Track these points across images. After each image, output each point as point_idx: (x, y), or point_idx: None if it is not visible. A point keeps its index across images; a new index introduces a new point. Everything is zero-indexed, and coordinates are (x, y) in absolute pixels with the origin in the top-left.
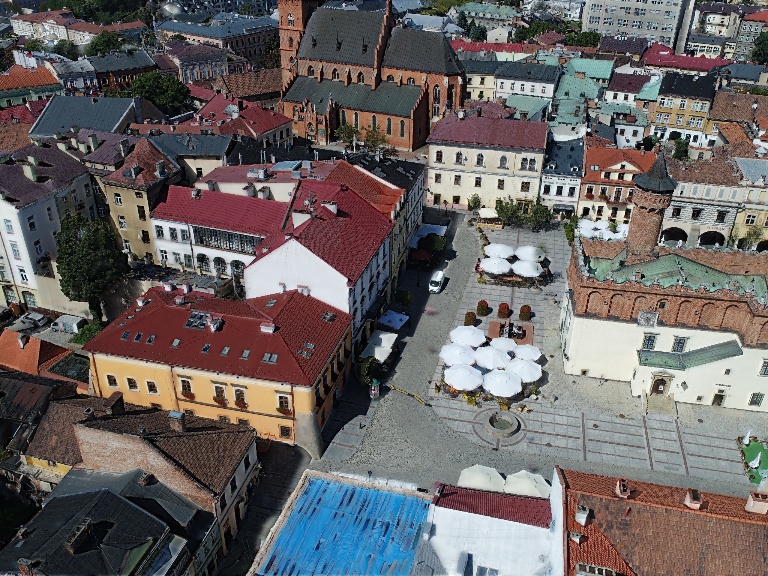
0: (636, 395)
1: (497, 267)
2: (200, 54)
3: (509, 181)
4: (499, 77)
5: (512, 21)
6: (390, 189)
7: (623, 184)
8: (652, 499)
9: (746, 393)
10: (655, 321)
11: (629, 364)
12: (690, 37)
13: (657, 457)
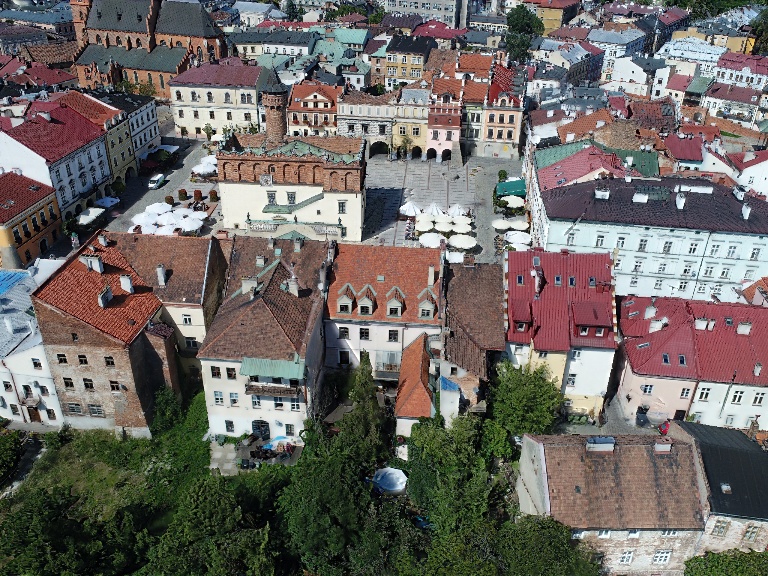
0: None
1: (203, 169)
2: (20, 33)
3: (235, 113)
4: (265, 43)
5: (326, 6)
6: (111, 110)
7: (318, 111)
8: None
9: None
10: (271, 182)
11: None
12: (486, 18)
13: None
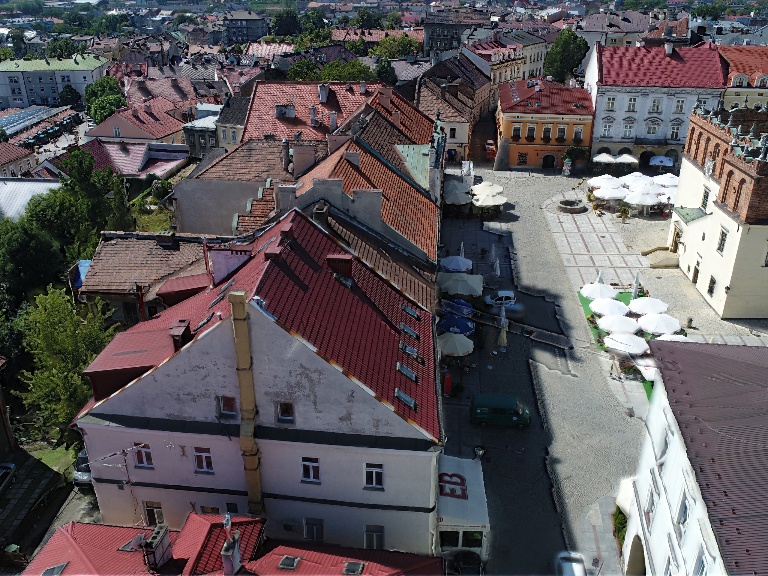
0: None
1: None
2: None
3: None
4: None
5: None
6: None
7: None
8: None
9: None
10: None
11: None
12: None
13: (580, 256)
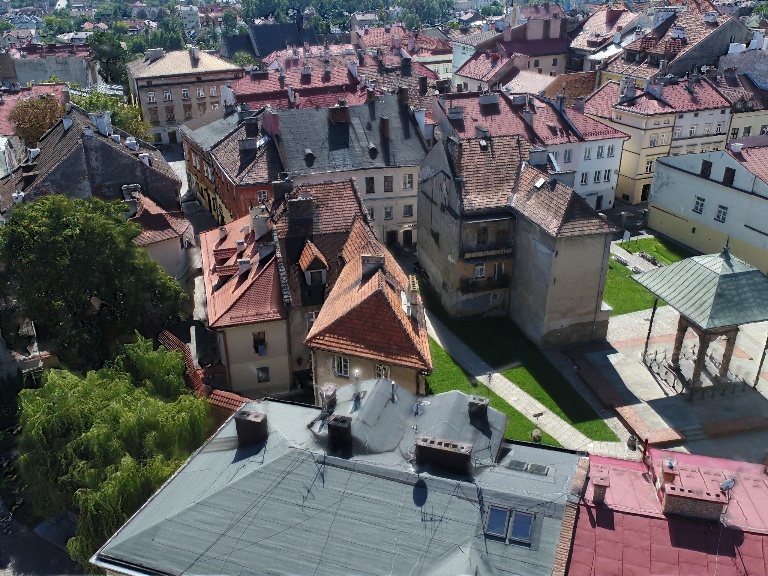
0: None
1: None
2: None
3: None
4: None
5: None
6: None
7: None
8: (693, 5)
9: None
10: None
11: None
12: None
13: None
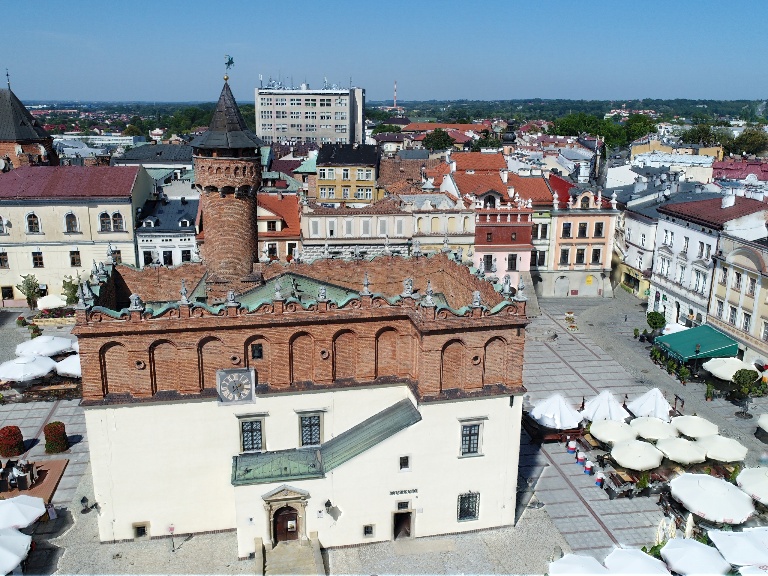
0: (245, 554)
1: (22, 369)
2: None
3: (87, 252)
4: (120, 161)
5: None
6: None
7: None
8: None
9: (448, 498)
10: (251, 387)
11: (226, 491)
12: None
13: None
